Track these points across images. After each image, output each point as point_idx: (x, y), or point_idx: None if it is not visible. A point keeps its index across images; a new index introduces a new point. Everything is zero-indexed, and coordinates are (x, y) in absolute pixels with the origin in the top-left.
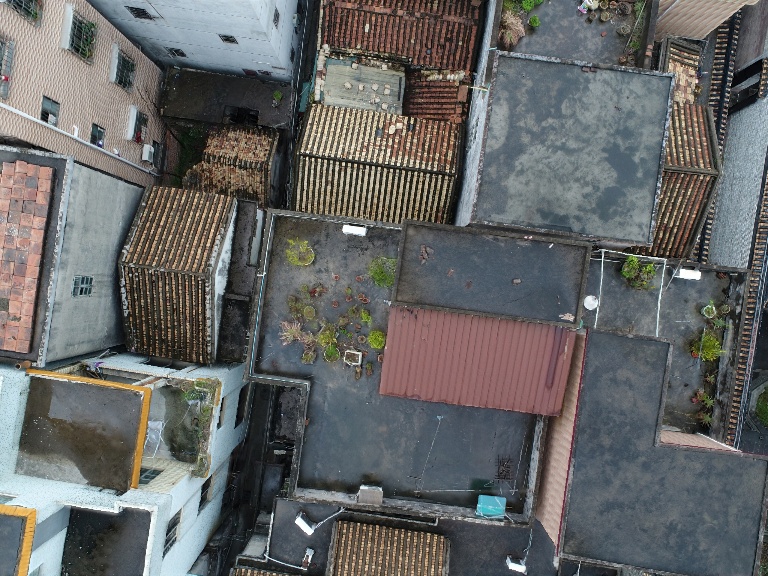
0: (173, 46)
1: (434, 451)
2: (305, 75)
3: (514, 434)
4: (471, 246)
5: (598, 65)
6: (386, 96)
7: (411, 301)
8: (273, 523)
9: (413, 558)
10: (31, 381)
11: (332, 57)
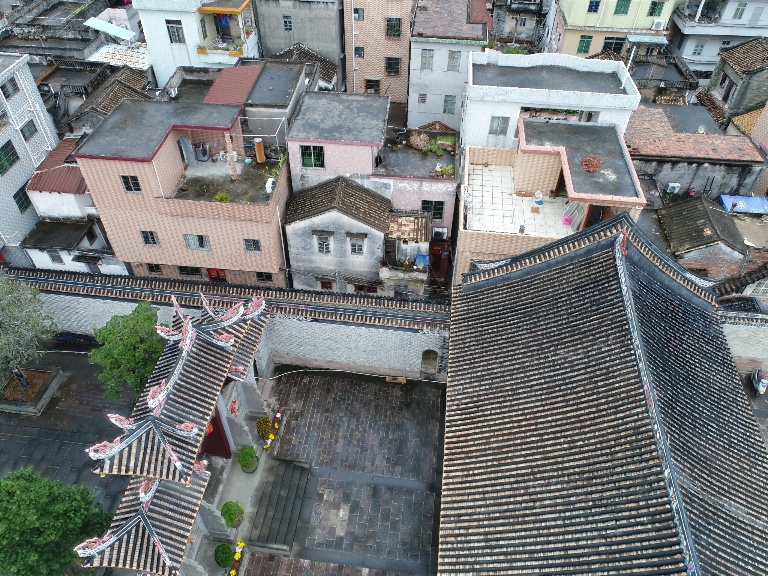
0: None
1: None
2: None
3: None
4: None
5: None
6: None
7: None
8: None
9: None
10: None
11: None
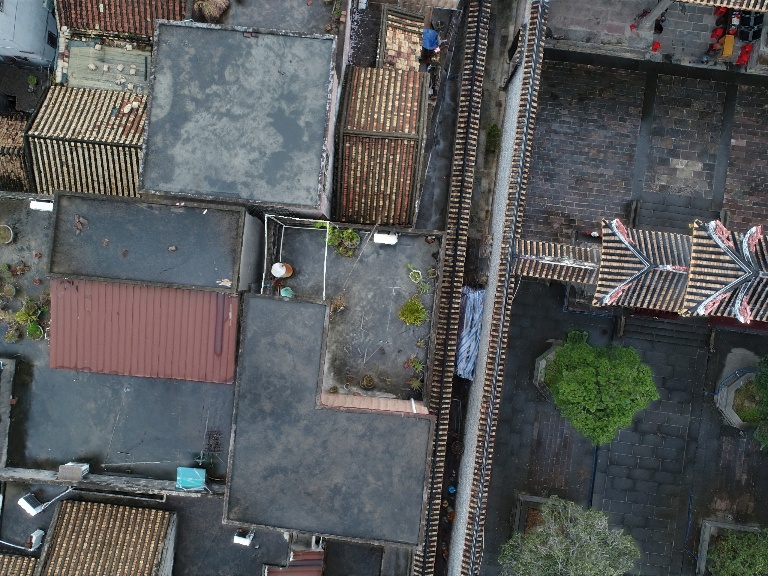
0: None
1: (143, 426)
2: None
3: (222, 406)
4: (126, 215)
5: (258, 30)
6: (132, 76)
7: (68, 272)
8: (3, 505)
9: (134, 535)
10: None
11: (74, 39)
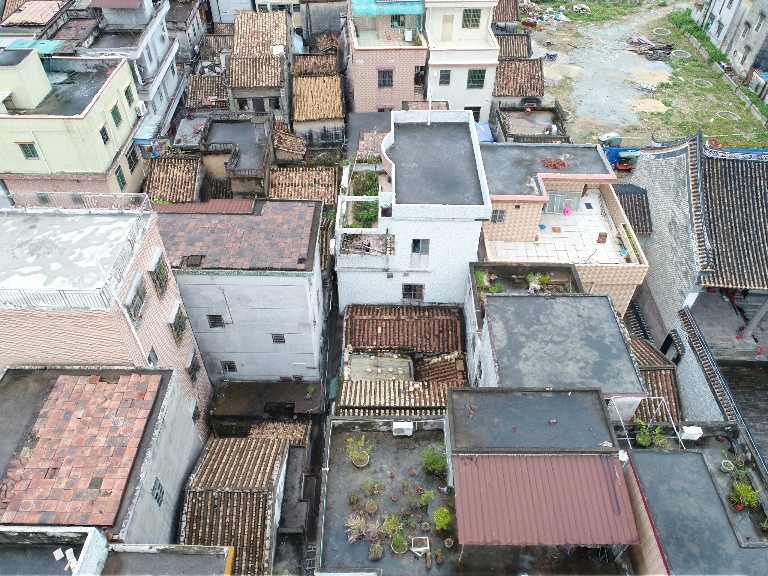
0: (229, 358)
1: None
2: (332, 373)
3: None
4: (506, 401)
5: (555, 294)
6: (400, 375)
7: None
8: None
9: None
10: (108, 556)
11: (354, 354)
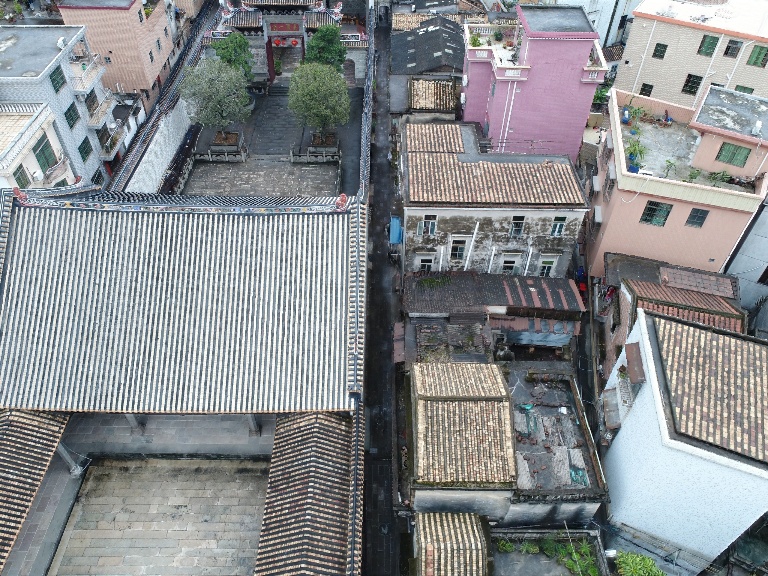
0: None
1: None
2: None
3: None
4: None
5: None
6: None
7: None
8: None
9: None
10: None
11: None
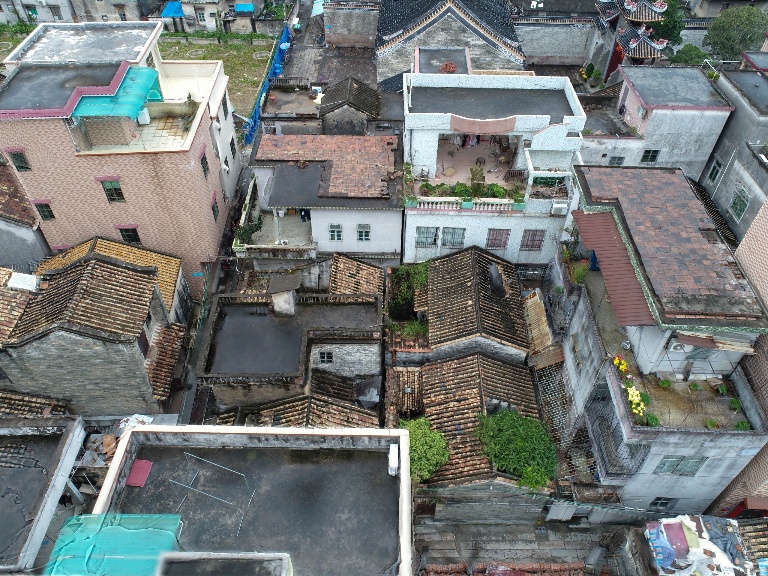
0: None
1: None
2: None
3: None
4: None
5: None
6: None
7: None
8: None
9: None
10: None
11: None
